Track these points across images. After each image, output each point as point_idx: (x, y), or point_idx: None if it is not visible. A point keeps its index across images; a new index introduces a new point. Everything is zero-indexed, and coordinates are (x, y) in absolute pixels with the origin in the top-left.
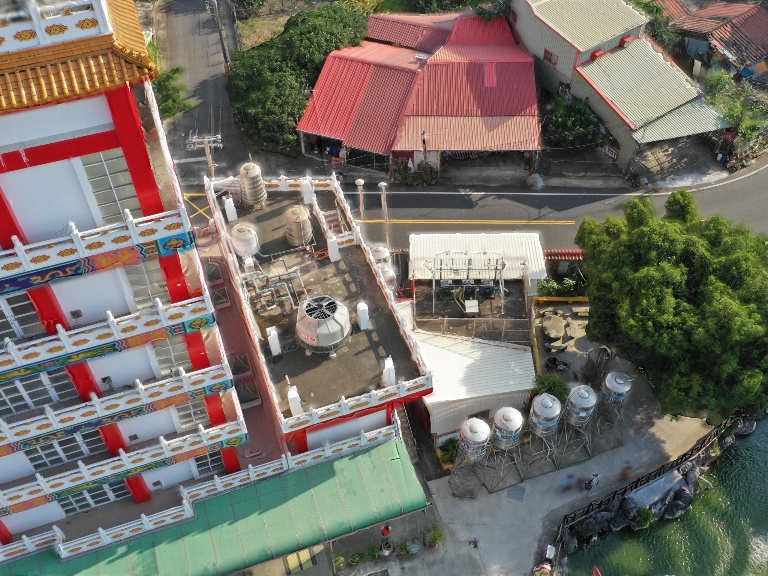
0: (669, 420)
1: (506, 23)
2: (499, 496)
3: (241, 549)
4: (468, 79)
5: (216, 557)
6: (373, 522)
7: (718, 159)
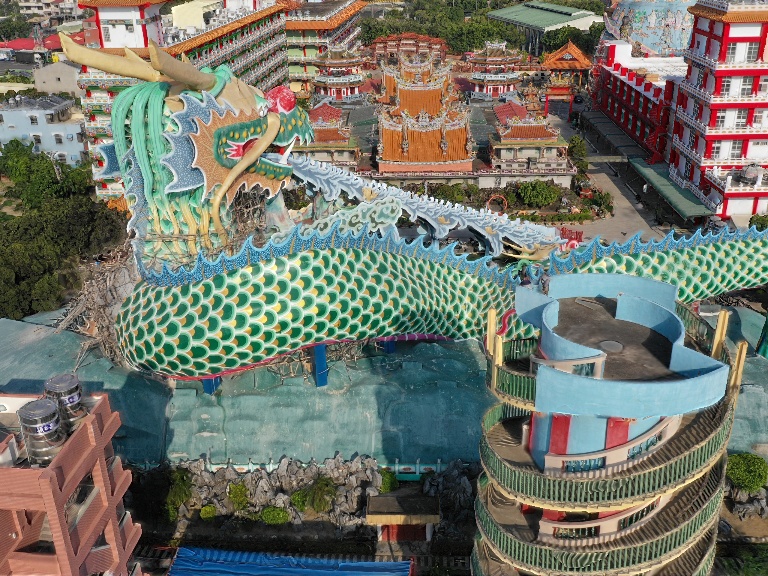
0: (746, 301)
1: None
2: None
3: None
4: None
5: None
6: None
7: None
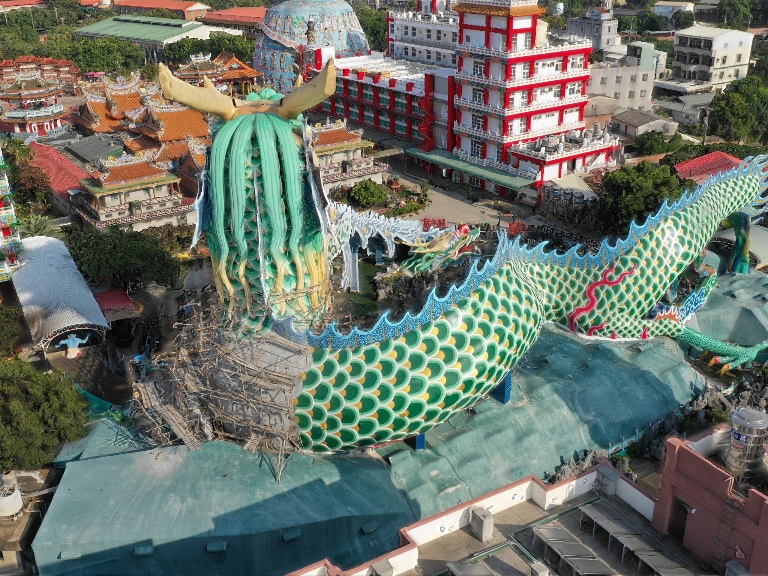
0: None
1: None
2: None
3: None
4: None
5: (476, 171)
6: None
7: None
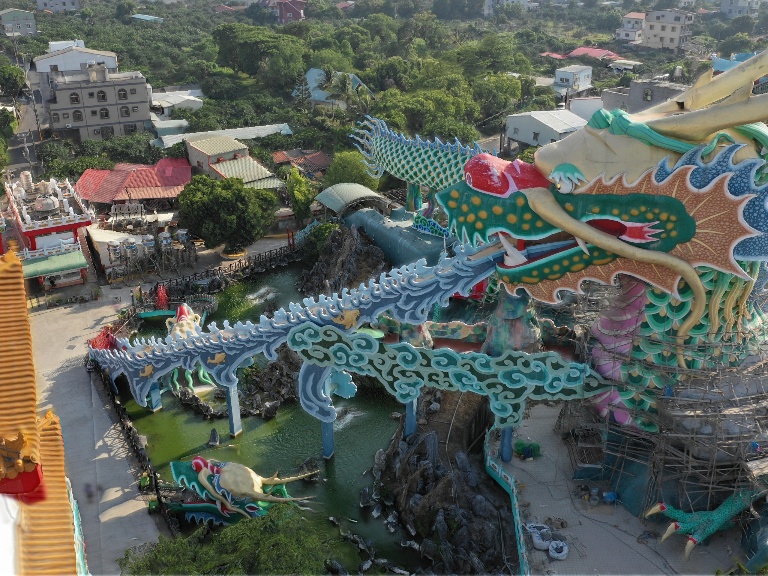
0: None
1: (186, 160)
2: (133, 287)
3: None
4: (157, 174)
5: None
6: (62, 270)
7: (286, 204)
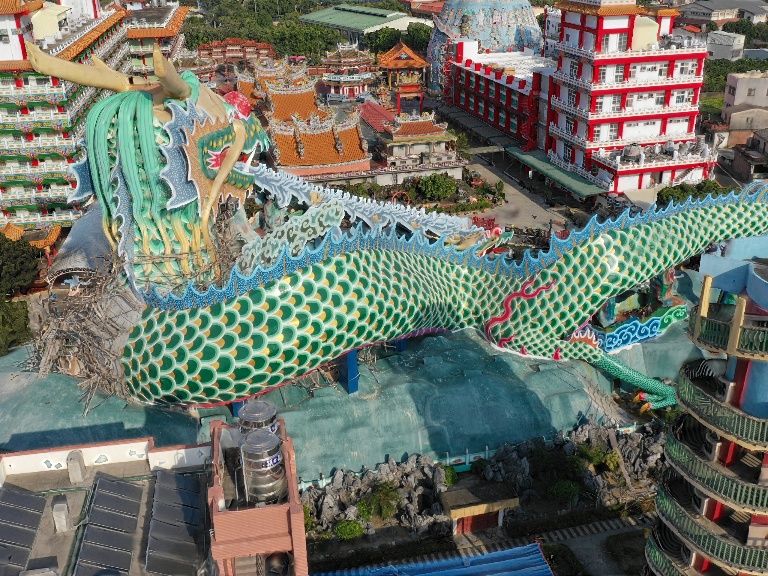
0: None
1: None
2: None
3: (560, 177)
4: None
5: (556, 175)
6: None
7: None
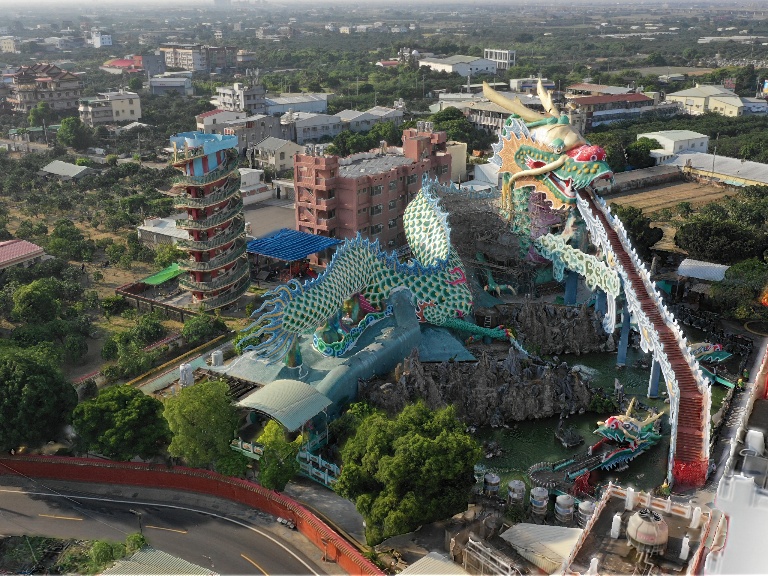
0: None
1: None
2: None
3: None
4: None
5: None
6: None
7: None
